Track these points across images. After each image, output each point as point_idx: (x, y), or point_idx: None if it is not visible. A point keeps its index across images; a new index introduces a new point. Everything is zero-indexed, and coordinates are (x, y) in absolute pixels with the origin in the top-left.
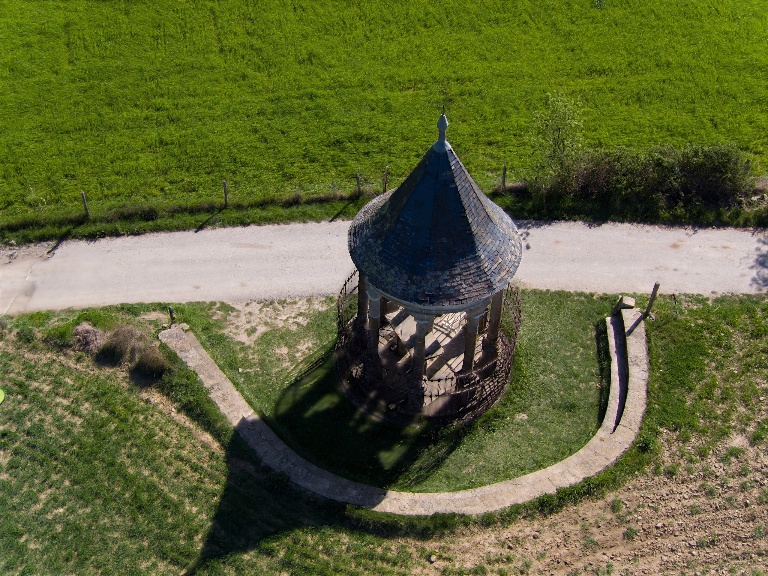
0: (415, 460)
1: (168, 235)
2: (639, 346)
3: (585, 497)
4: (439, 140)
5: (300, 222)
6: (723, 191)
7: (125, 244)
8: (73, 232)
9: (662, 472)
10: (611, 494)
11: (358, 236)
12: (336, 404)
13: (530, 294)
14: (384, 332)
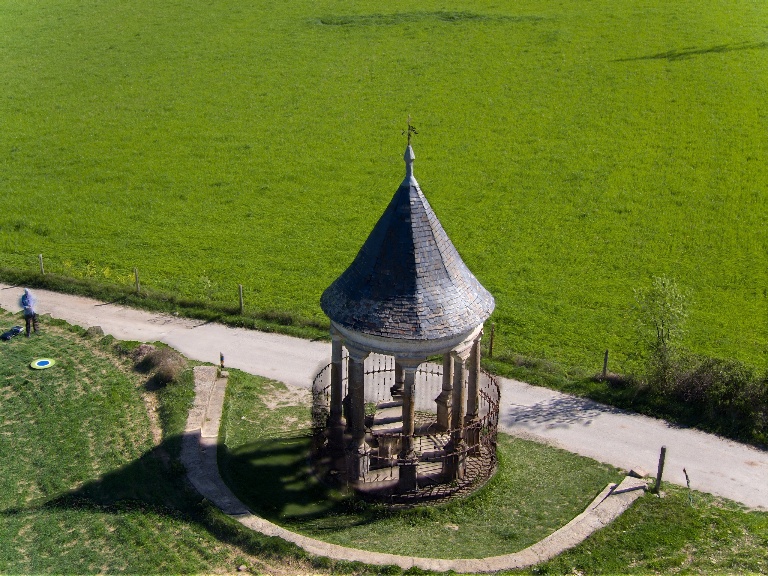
0: (318, 517)
1: (288, 337)
2: (616, 504)
3: None
4: None
5: None
6: None
7: (252, 334)
8: (222, 318)
9: None
10: None
11: None
12: (293, 460)
13: (555, 451)
14: None
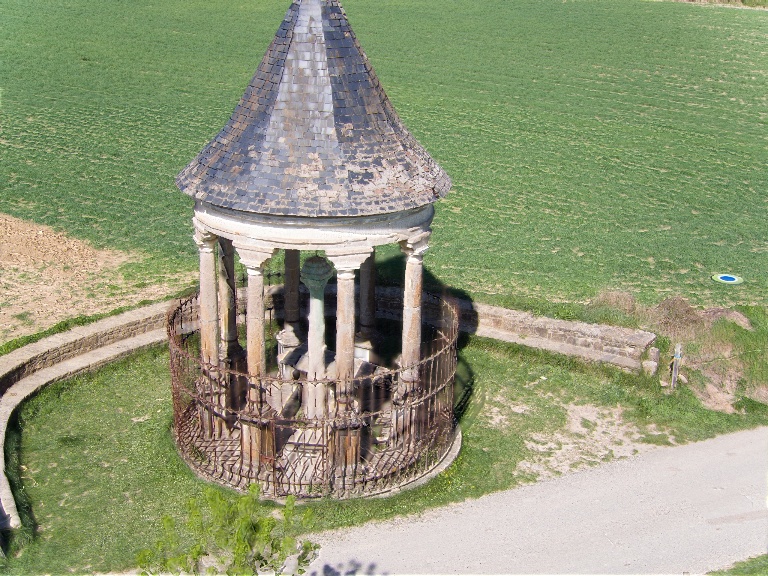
0: None
1: None
2: None
3: None
4: None
5: (721, 570)
6: None
7: None
8: None
9: None
10: None
11: None
12: None
13: (188, 550)
14: None
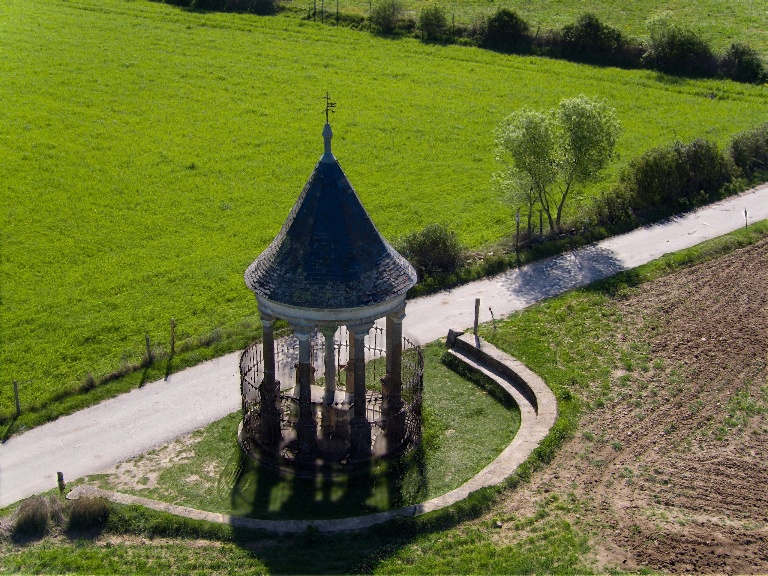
0: (399, 490)
1: None
2: (494, 350)
3: (562, 441)
4: (327, 152)
5: (109, 398)
6: (448, 259)
7: None
8: None
9: (594, 407)
10: (576, 433)
11: (269, 283)
12: (288, 487)
13: (370, 364)
14: (281, 423)
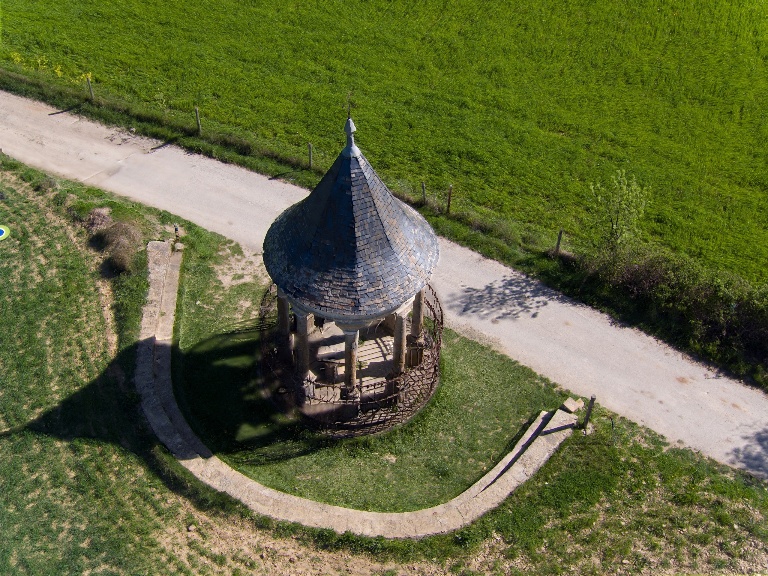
0: (266, 445)
1: (247, 172)
2: (543, 449)
3: (367, 552)
4: None
5: None
6: None
7: (210, 166)
8: (180, 140)
9: (459, 572)
10: (394, 564)
11: (285, 213)
12: (245, 366)
13: (497, 357)
14: None
